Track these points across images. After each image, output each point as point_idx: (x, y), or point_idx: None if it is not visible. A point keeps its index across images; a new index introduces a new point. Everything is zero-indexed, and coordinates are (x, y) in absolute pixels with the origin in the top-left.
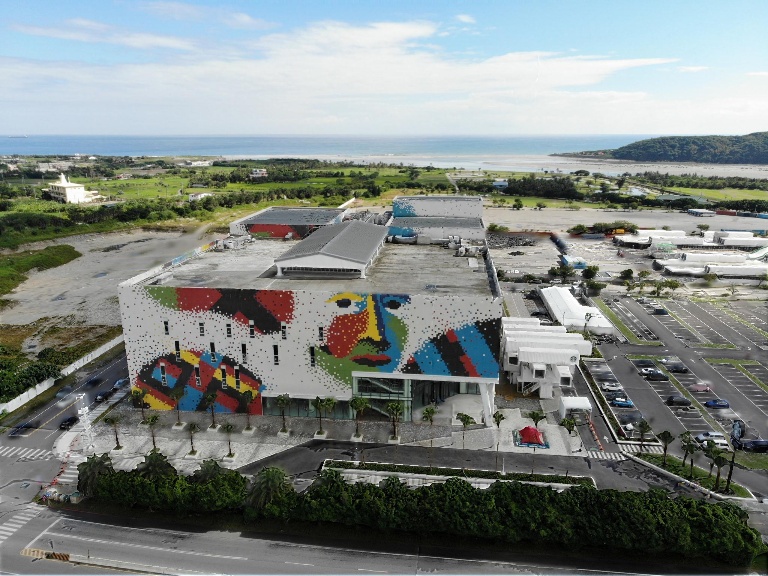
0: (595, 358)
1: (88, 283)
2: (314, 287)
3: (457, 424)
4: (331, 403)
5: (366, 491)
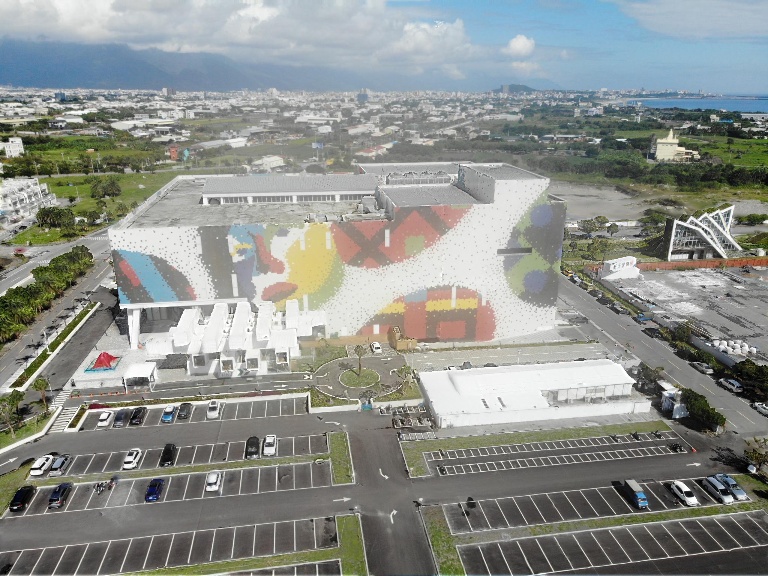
0: (310, 401)
1: None
2: (180, 200)
3: (140, 335)
4: None
5: (8, 296)
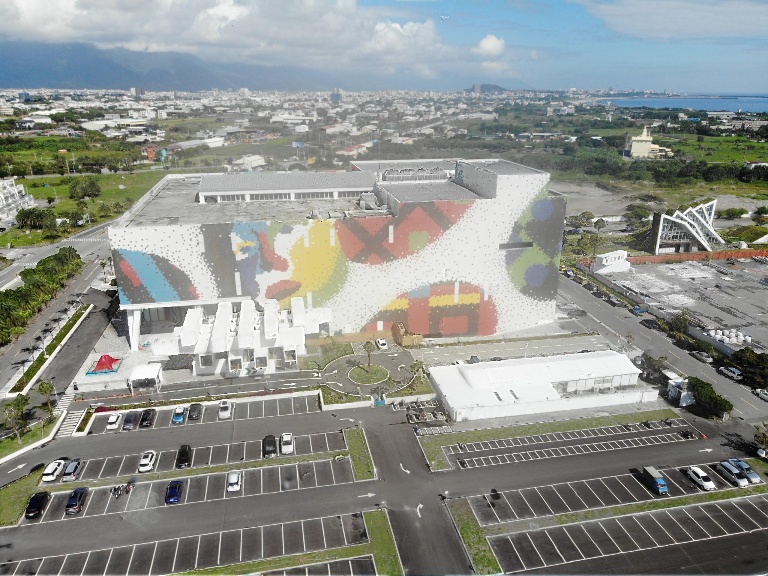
0: (322, 398)
1: None
2: None
3: None
4: (75, 262)
5: None
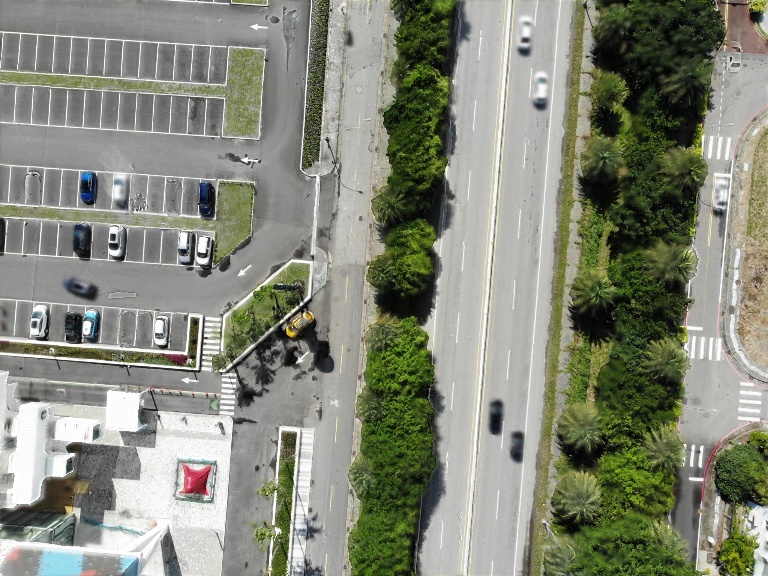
0: None
1: None
2: None
3: (163, 573)
4: None
5: None
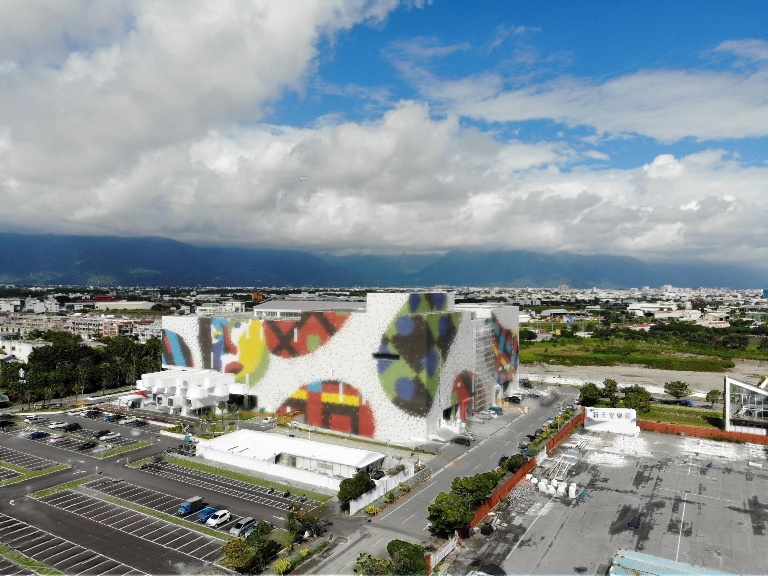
0: None
1: (598, 374)
2: None
3: None
4: None
5: None
